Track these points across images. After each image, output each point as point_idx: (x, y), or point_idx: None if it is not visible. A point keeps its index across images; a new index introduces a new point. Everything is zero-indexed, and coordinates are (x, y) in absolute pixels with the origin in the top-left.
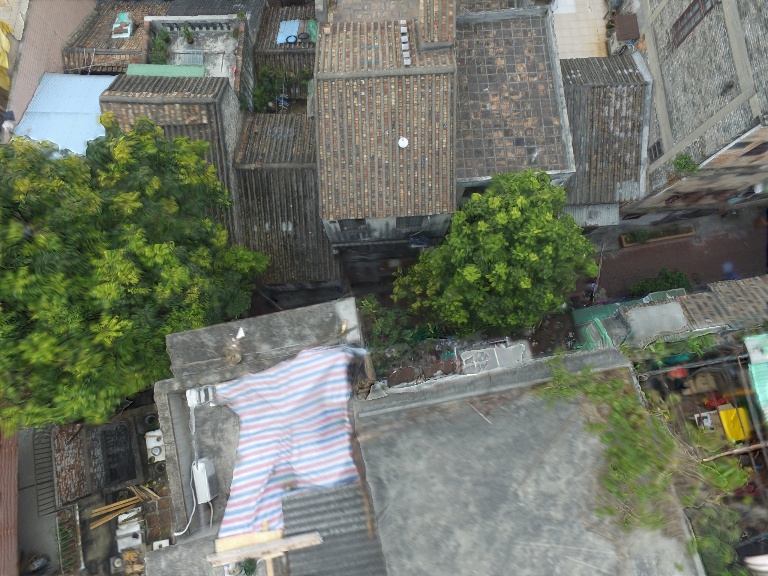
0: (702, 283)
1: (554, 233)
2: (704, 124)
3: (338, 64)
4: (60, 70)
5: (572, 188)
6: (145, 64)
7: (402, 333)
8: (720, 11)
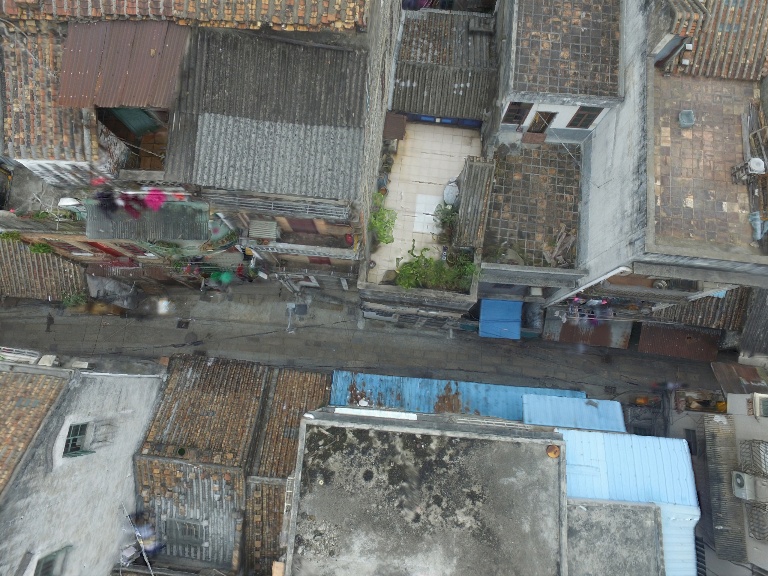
0: None
1: None
2: None
3: (767, 1)
4: None
5: None
6: None
7: None
8: None
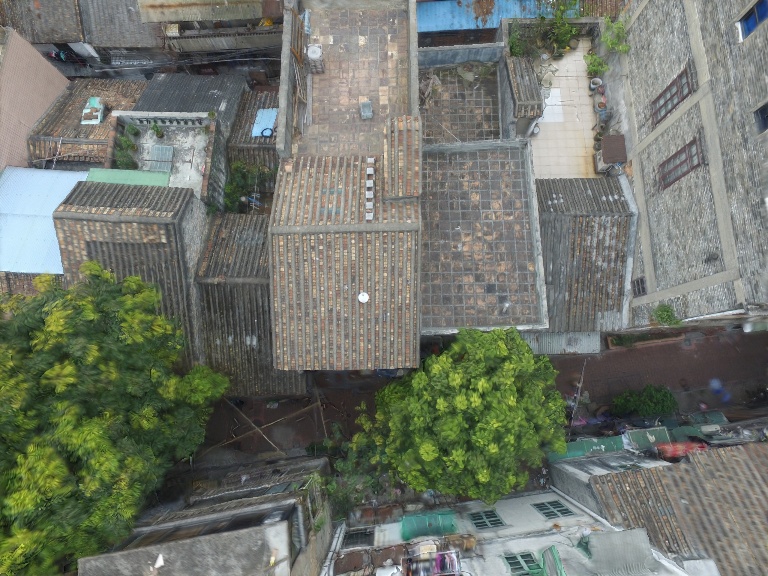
0: (690, 390)
1: (516, 425)
2: (687, 284)
3: (296, 213)
4: (25, 159)
5: (551, 317)
6: (107, 169)
7: (361, 480)
8: (707, 173)
